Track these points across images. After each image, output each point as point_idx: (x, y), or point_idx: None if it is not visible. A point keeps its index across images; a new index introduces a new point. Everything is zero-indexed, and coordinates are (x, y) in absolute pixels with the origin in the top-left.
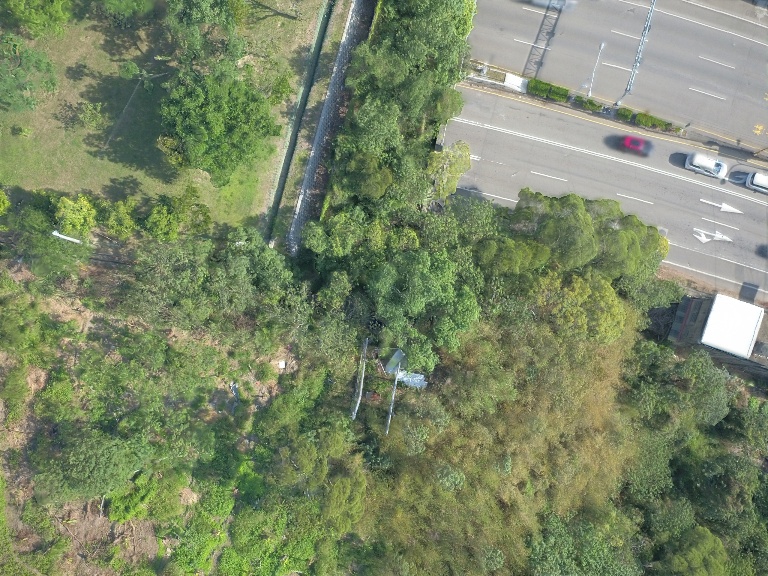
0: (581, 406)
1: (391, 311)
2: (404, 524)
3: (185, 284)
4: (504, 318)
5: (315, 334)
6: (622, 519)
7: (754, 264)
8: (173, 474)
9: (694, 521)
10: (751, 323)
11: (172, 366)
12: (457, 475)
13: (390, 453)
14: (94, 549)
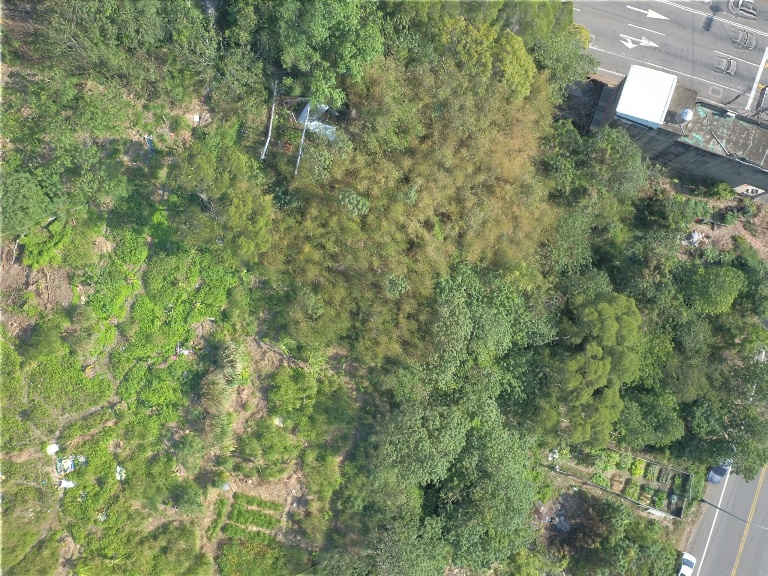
0: (490, 153)
1: (294, 36)
2: (312, 262)
3: (93, 15)
4: (411, 60)
5: (225, 76)
6: (533, 271)
7: (680, 69)
8: (87, 222)
9: (610, 289)
10: (664, 91)
11: (82, 101)
12: (359, 198)
13: (298, 192)
14: (9, 297)
